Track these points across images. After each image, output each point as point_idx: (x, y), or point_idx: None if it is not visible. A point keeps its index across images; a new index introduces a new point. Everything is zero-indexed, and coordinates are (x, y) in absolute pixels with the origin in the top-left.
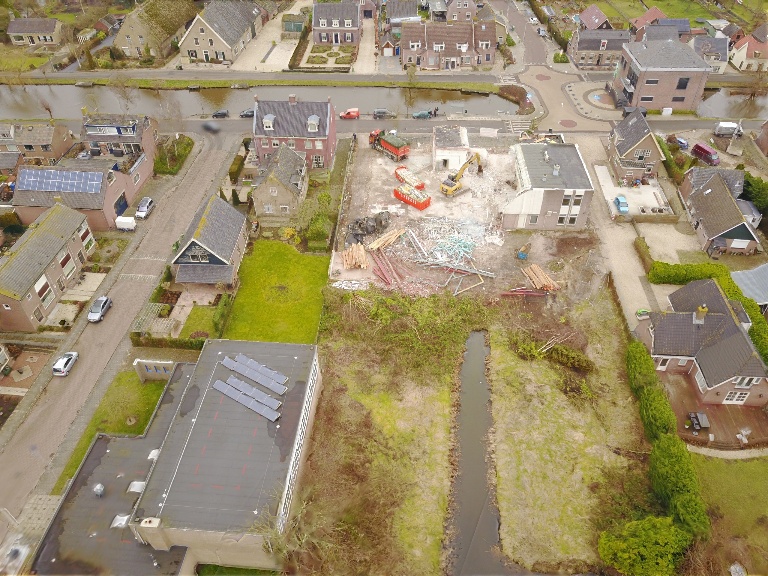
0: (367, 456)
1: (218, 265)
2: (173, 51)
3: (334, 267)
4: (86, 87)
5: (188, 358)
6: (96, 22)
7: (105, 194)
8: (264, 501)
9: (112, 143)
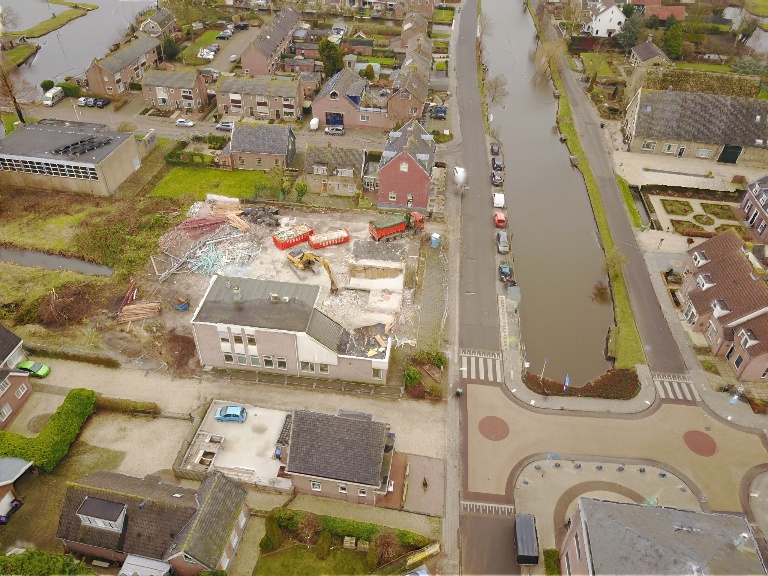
0: (39, 212)
1: None
2: None
3: (221, 202)
4: None
5: None
6: None
7: (320, 99)
8: (4, 149)
9: None
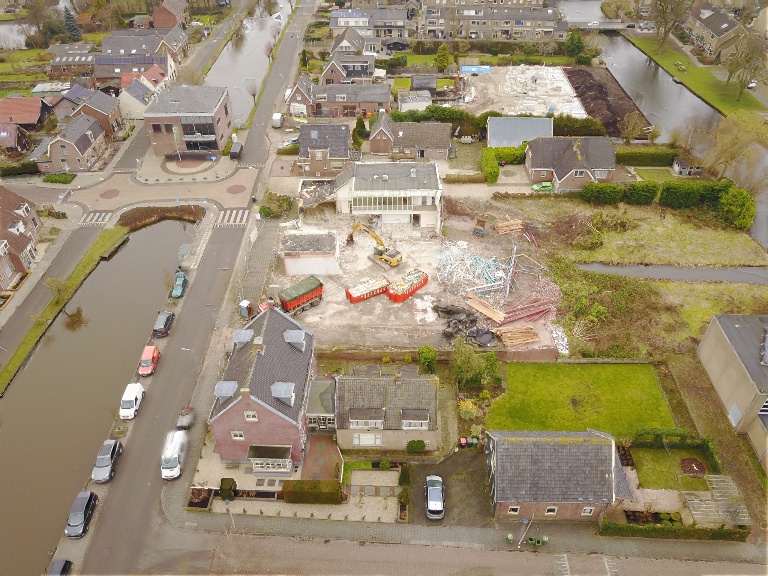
0: None
1: None
2: None
3: None
4: None
5: (730, 469)
6: None
7: None
8: None
9: None
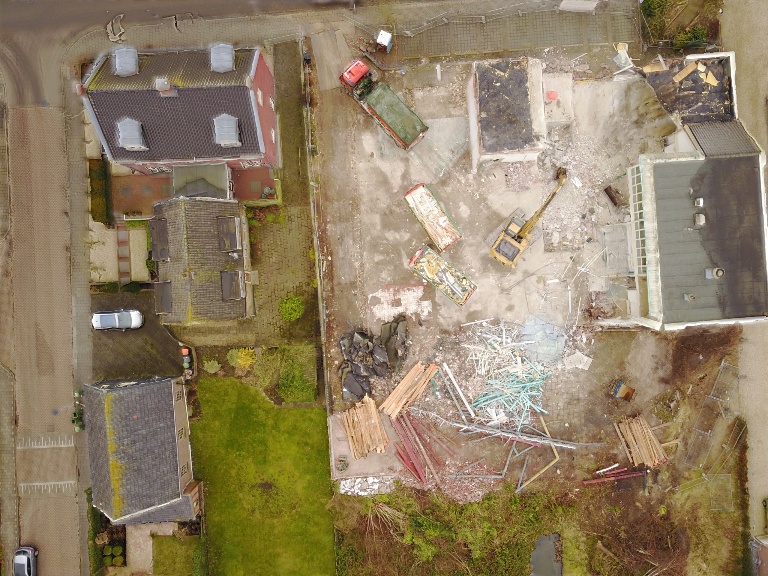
0: None
1: None
2: None
3: (336, 450)
4: None
5: None
6: None
7: None
8: None
9: None
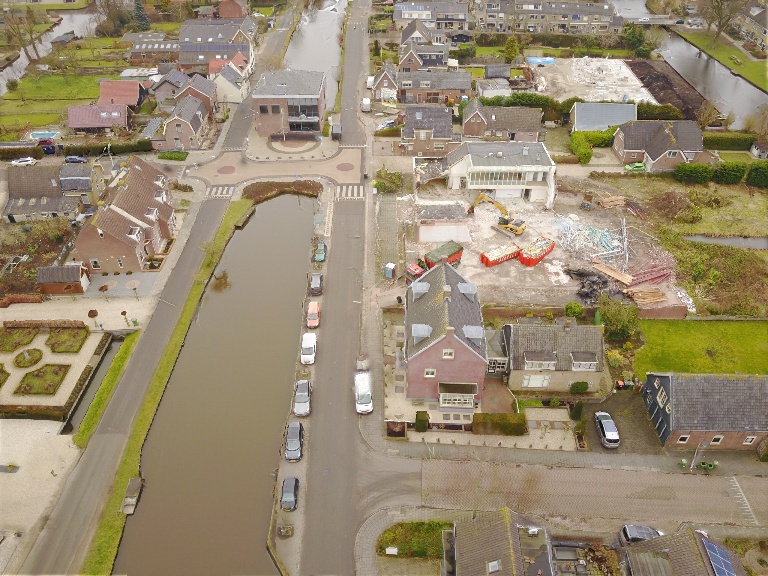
0: None
1: None
2: None
3: None
4: None
5: None
6: None
7: None
8: None
9: None
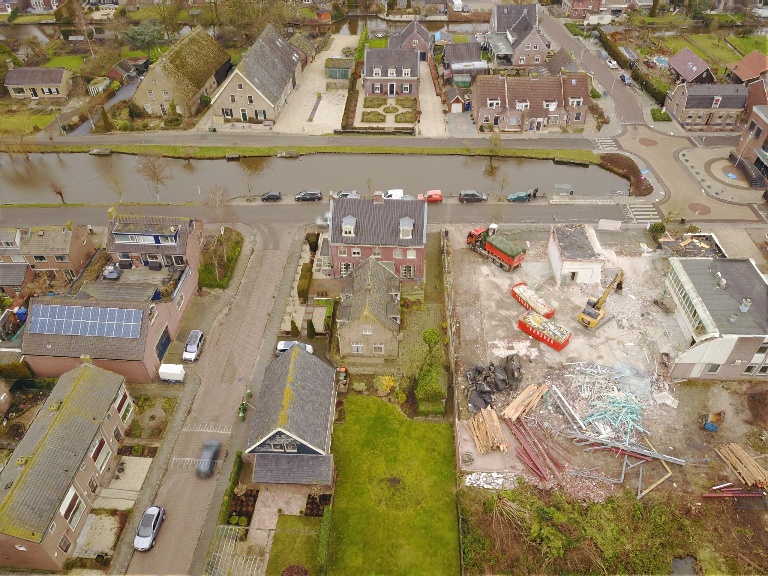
0: None
1: (309, 455)
2: (203, 107)
3: (462, 448)
4: (102, 156)
5: None
6: (109, 69)
7: (146, 339)
8: None
9: (147, 254)
